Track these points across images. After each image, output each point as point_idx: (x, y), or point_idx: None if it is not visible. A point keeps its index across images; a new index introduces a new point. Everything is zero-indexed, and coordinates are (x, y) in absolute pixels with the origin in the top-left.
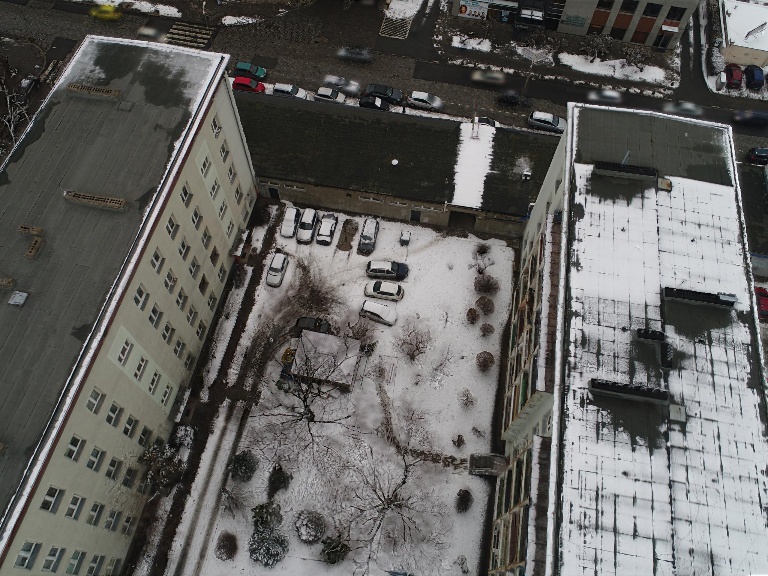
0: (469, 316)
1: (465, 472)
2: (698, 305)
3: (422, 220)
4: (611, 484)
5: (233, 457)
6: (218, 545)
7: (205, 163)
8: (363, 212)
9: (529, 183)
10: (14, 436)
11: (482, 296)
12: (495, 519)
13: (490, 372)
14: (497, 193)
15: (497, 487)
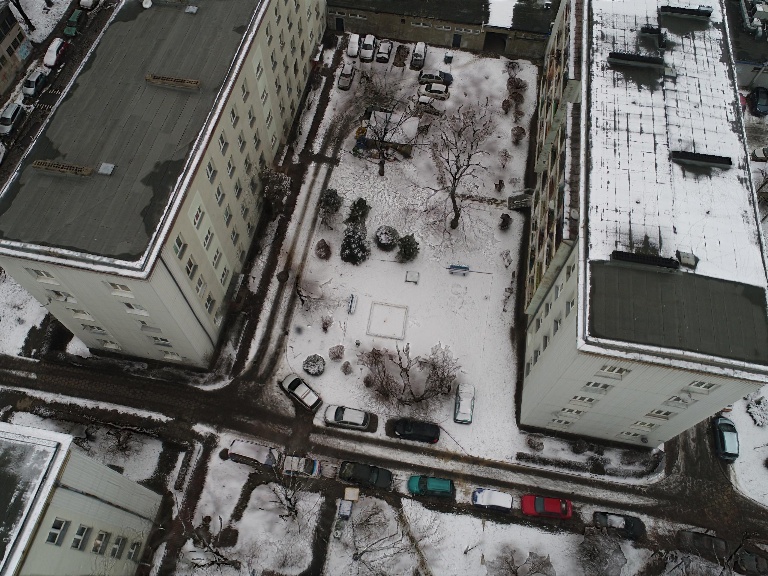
0: (504, 104)
1: (505, 208)
2: (685, 18)
3: (462, 45)
4: (624, 108)
5: (325, 190)
6: (318, 246)
7: None
8: (413, 40)
9: (550, 11)
10: (204, 82)
11: (514, 92)
12: (533, 215)
13: (522, 146)
14: (524, 18)
15: (533, 199)
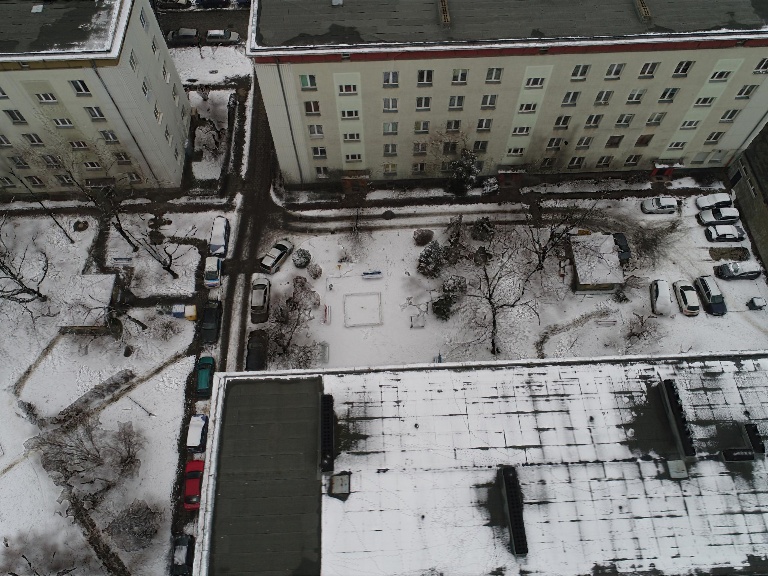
0: None
1: None
2: None
3: None
4: (577, 407)
5: (487, 217)
6: None
7: (723, 75)
8: (764, 260)
9: None
10: (456, 29)
11: None
12: None
13: None
14: None
15: None
